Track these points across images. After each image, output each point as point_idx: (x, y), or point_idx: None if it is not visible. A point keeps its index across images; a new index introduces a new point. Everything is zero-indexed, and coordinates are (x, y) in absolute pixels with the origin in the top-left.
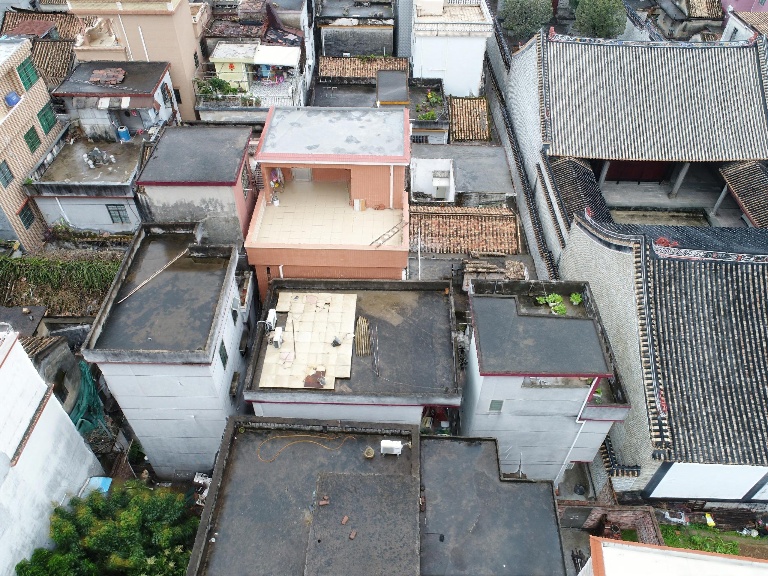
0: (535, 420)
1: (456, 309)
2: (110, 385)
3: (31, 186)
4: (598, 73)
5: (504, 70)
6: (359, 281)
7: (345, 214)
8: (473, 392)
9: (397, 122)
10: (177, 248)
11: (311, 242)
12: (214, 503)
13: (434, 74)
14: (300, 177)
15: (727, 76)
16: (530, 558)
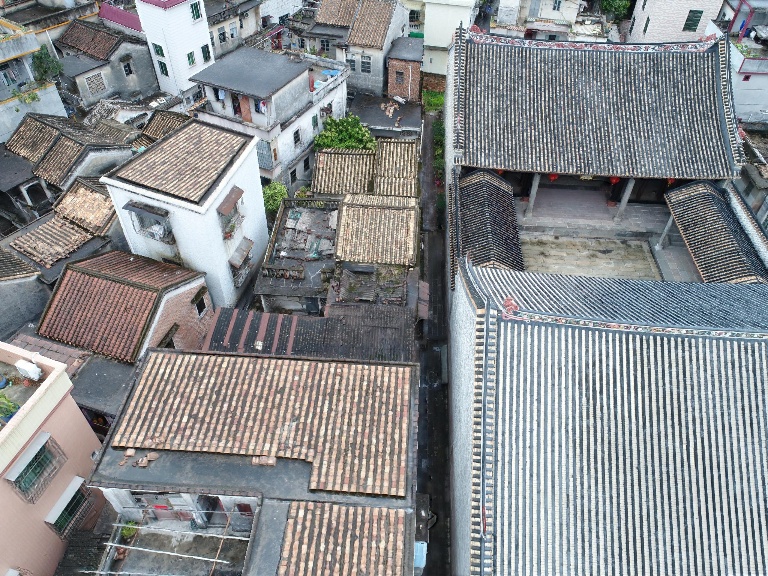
0: None
1: None
2: None
3: None
4: None
5: None
6: None
7: None
8: None
9: None
10: None
11: None
12: None
13: None
14: None
15: None
16: None
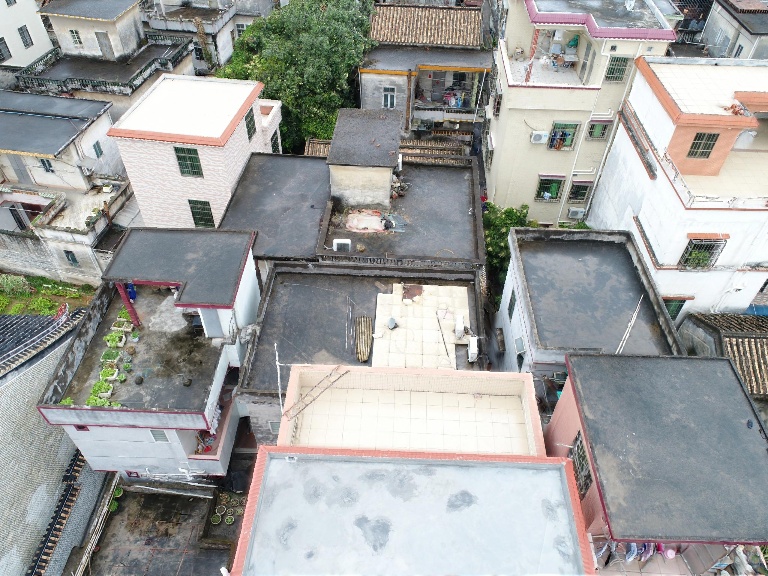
0: None
1: (211, 567)
2: None
3: None
4: None
5: None
6: None
7: None
8: None
9: None
10: None
11: (440, 427)
12: None
13: None
14: None
15: None
16: (256, 197)
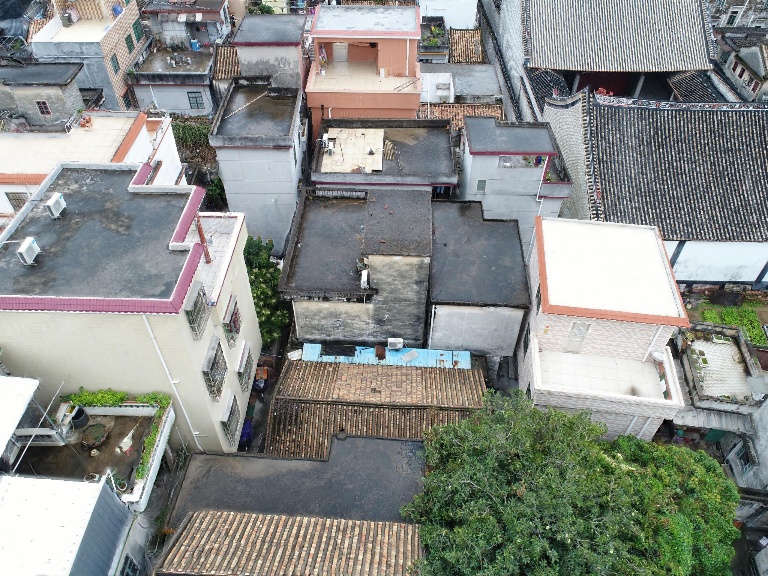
0: (509, 200)
1: None
2: (221, 170)
3: (133, 75)
4: (570, 3)
5: (496, 14)
6: (385, 120)
7: (374, 79)
8: (466, 182)
9: (411, 14)
10: (258, 92)
11: None
12: (298, 229)
13: (437, 13)
14: (339, 58)
15: (674, 5)
16: (501, 253)
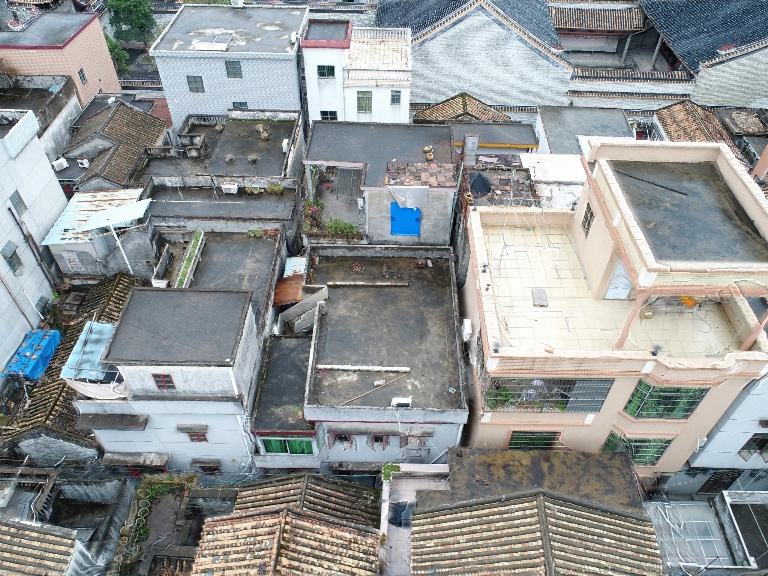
0: None
1: None
2: None
3: None
4: (500, 7)
5: None
6: None
7: None
8: None
9: None
10: None
11: None
12: None
13: None
14: None
15: None
16: None
